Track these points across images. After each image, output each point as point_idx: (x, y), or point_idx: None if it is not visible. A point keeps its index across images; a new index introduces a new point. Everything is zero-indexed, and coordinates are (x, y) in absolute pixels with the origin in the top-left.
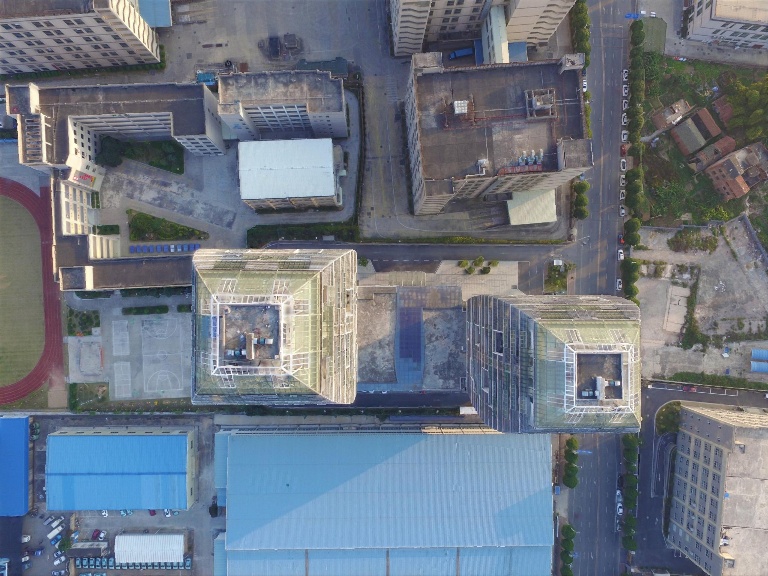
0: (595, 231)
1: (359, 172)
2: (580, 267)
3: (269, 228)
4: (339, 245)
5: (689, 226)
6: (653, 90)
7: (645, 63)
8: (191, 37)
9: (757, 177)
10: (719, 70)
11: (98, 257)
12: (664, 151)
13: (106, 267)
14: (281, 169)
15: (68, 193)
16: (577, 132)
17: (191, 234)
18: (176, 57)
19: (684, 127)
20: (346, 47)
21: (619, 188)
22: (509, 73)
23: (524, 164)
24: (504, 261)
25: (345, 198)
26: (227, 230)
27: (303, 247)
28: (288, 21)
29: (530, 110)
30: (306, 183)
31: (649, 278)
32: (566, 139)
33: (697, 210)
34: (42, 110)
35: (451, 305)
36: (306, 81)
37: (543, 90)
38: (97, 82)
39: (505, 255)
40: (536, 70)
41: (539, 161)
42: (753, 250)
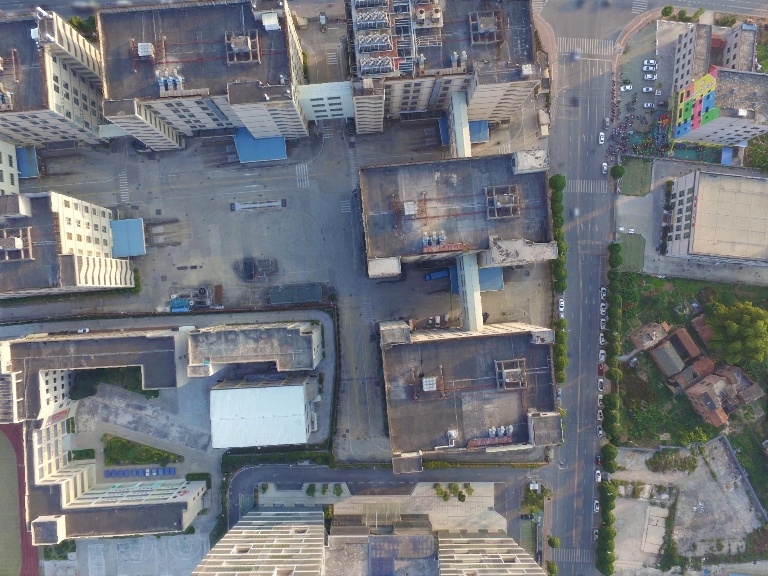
0: (572, 451)
1: (334, 395)
2: (557, 487)
3: (244, 452)
4: (314, 468)
5: (667, 447)
6: (631, 314)
7: (623, 285)
8: (166, 259)
9: (736, 404)
10: (699, 286)
11: (71, 499)
12: (642, 370)
13: (78, 515)
14: (252, 418)
15: (41, 437)
16: (548, 401)
17: (165, 463)
18: (151, 280)
19: (662, 351)
20: (321, 268)
21: (597, 408)
22: (479, 341)
23: (494, 436)
24: (480, 482)
25: (320, 420)
26: (202, 453)
27: (278, 470)
28: (263, 242)
29: (500, 382)
30: (278, 431)
31: (627, 499)
32: (536, 416)
33: (675, 432)
34: (13, 364)
35: (423, 555)
36: (276, 336)
37: (513, 360)
38: (72, 306)
39: (481, 476)
40: (506, 338)
41: (509, 433)
42: (733, 470)
